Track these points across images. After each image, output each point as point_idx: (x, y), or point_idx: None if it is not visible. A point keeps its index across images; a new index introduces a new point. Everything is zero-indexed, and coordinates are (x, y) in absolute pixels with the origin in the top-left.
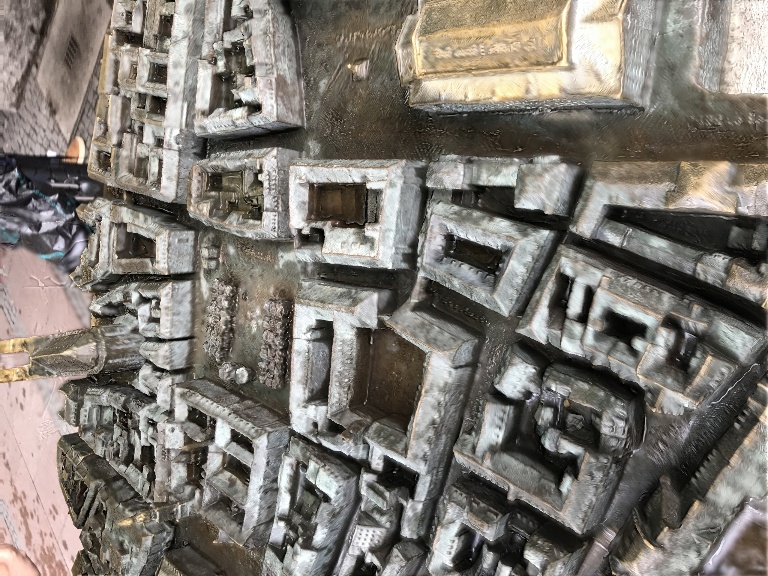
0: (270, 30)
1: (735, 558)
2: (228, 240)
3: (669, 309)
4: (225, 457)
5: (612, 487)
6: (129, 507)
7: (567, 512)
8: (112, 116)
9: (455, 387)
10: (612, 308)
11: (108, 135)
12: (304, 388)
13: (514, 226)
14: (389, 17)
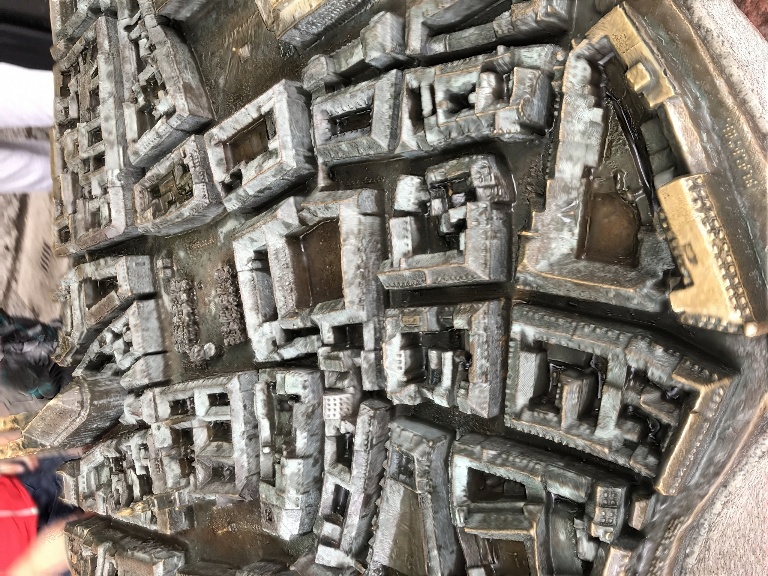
0: (171, 53)
1: (608, 236)
2: (177, 247)
3: (483, 61)
4: (210, 430)
5: (504, 238)
6: (137, 549)
7: (470, 261)
8: (65, 191)
9: (369, 234)
10: (450, 89)
11: (64, 208)
12: (257, 313)
13: (371, 80)
14: (255, 5)
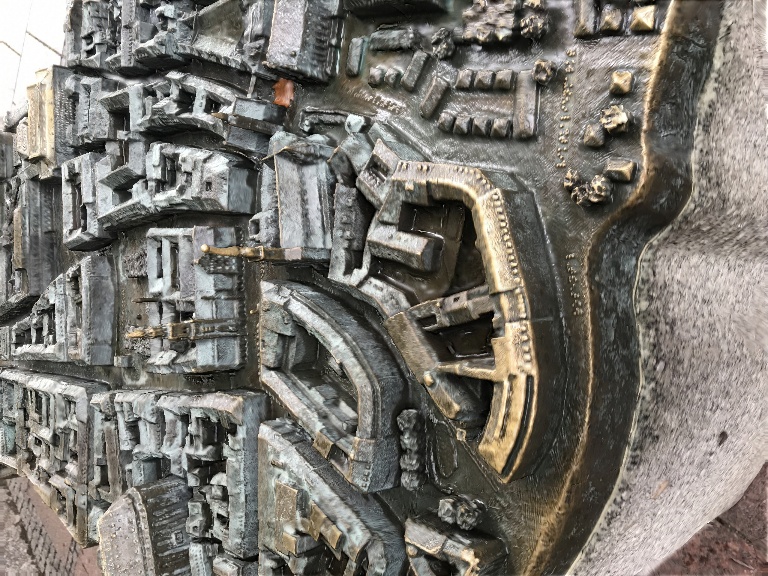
0: None
1: None
2: (122, 347)
3: None
4: None
5: None
6: None
7: None
8: (56, 482)
9: None
10: None
11: (62, 492)
12: None
13: None
14: None
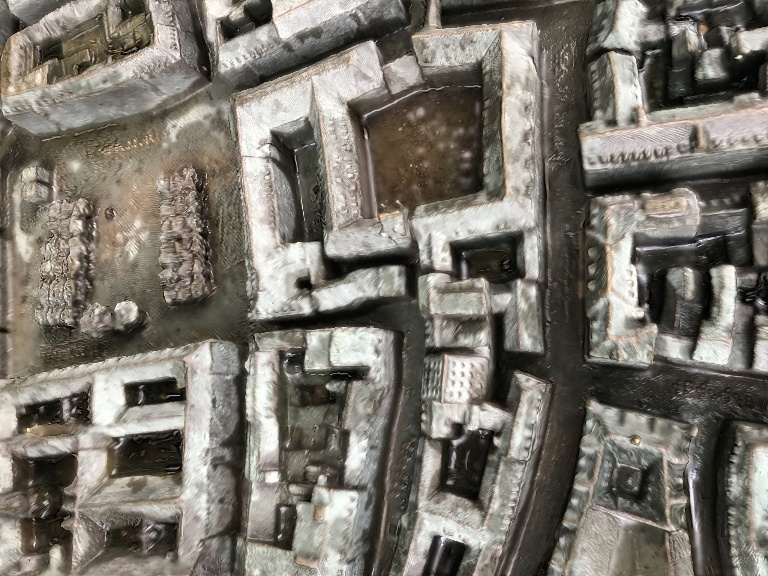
0: None
1: None
2: (67, 155)
3: None
4: (111, 457)
5: None
6: None
7: None
8: None
9: (534, 93)
10: None
11: None
12: (272, 229)
13: None
14: None
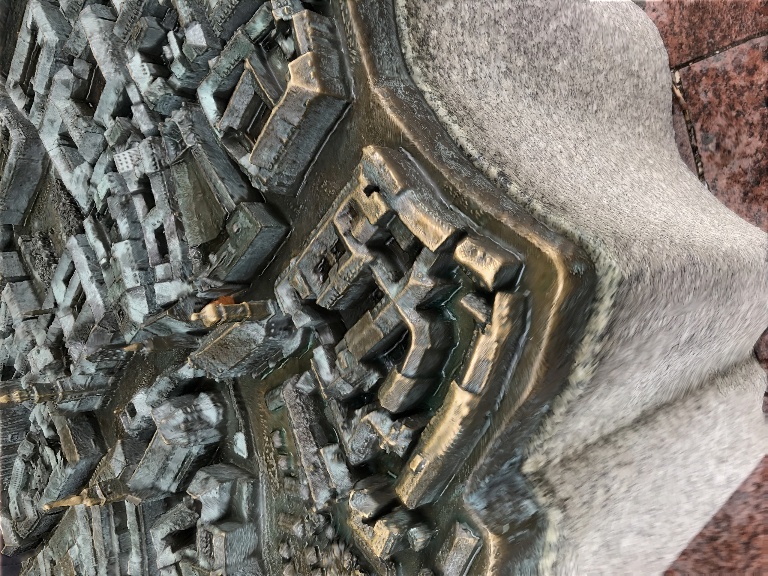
0: None
1: None
2: (33, 223)
3: None
4: (76, 317)
5: None
6: None
7: None
8: None
9: (111, 30)
10: None
11: None
12: (70, 170)
13: None
14: (26, 1)
